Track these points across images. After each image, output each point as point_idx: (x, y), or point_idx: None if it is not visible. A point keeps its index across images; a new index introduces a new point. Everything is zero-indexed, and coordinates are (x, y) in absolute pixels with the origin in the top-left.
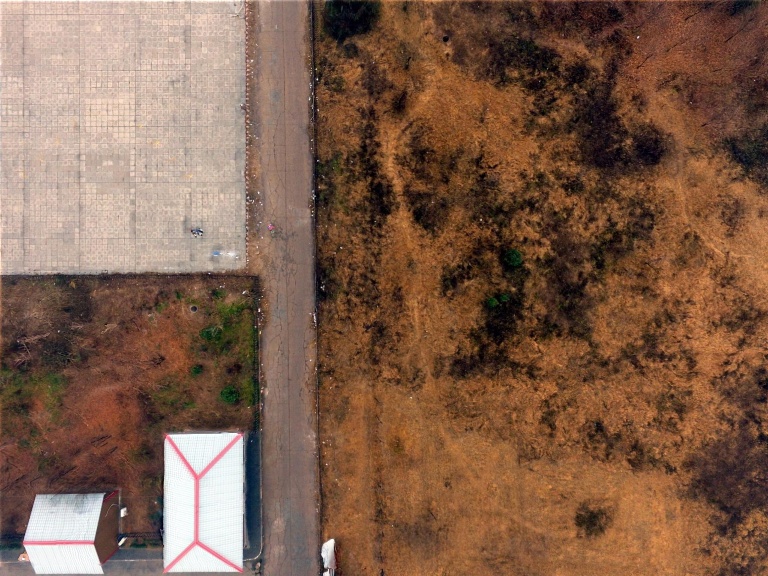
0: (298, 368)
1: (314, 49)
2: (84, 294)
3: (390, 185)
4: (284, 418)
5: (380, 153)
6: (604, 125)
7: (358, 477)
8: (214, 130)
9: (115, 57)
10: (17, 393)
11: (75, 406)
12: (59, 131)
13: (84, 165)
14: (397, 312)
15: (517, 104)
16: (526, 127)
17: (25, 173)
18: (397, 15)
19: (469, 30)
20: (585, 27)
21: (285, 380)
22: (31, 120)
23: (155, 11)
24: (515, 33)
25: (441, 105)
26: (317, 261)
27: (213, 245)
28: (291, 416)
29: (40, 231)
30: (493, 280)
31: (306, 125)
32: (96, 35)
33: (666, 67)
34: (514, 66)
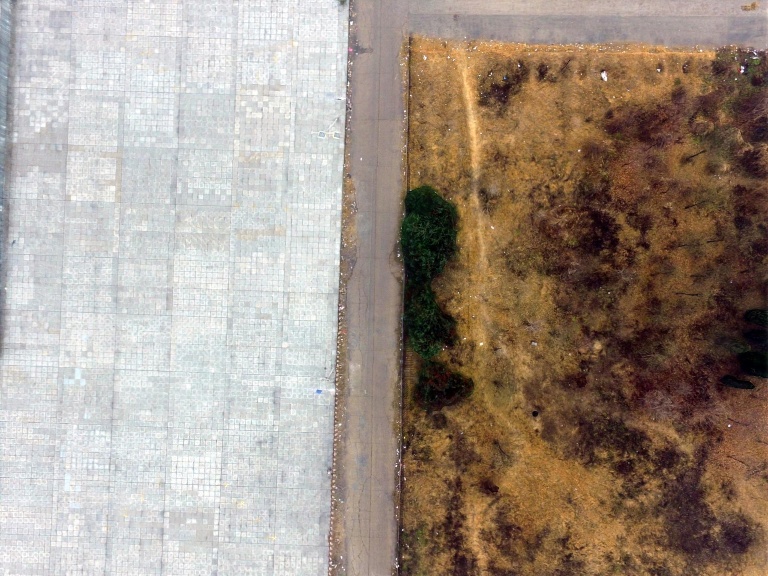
0: None
1: (403, 418)
2: None
3: (475, 559)
4: None
5: (466, 527)
6: (692, 511)
7: None
8: (299, 493)
9: (204, 415)
10: None
11: None
12: (144, 487)
13: (168, 522)
14: None
15: (606, 486)
16: (614, 510)
17: (108, 528)
18: (487, 387)
19: (559, 408)
20: (676, 412)
21: None
22: (117, 475)
23: (245, 371)
24: (605, 414)
25: (529, 483)
26: None
27: None
28: None
29: None
30: None
31: (392, 491)
32: (186, 392)
33: (757, 457)
34: (603, 447)
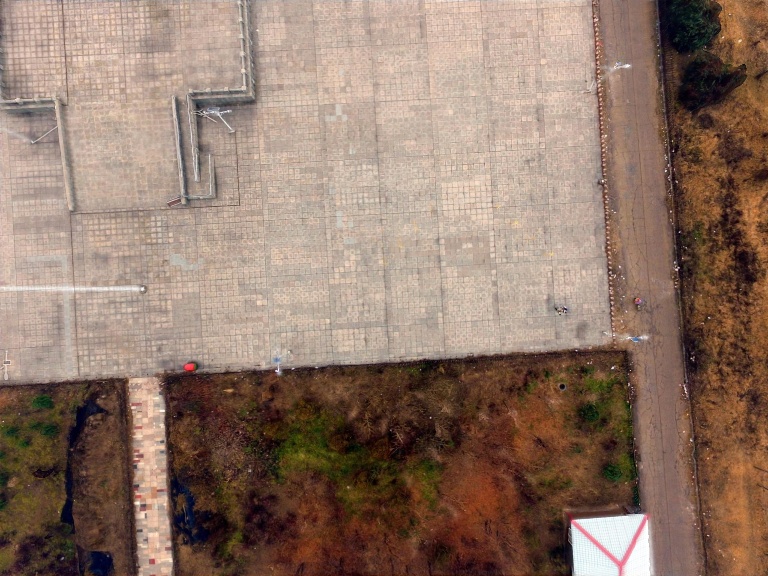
0: (671, 440)
1: (669, 121)
2: (453, 379)
3: (754, 253)
4: (660, 491)
5: (743, 221)
6: None
7: (742, 547)
8: (572, 207)
9: (469, 139)
10: (392, 482)
11: (451, 492)
12: (417, 216)
13: (444, 249)
14: None
15: None
16: None
17: (385, 260)
18: (750, 83)
19: None
20: None
21: (659, 453)
22: (388, 207)
23: (506, 91)
24: None
25: None
26: (686, 332)
27: (578, 322)
28: (668, 489)
29: (403, 318)
30: None
31: (663, 197)
32: (449, 118)
33: None
34: None
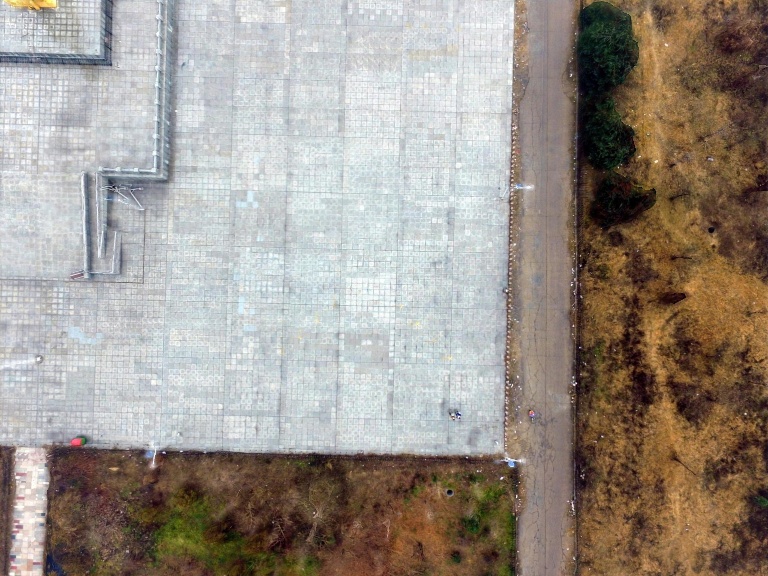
0: (554, 556)
1: (579, 236)
2: (340, 475)
3: (653, 375)
4: None
5: (644, 343)
6: None
7: None
8: (475, 313)
9: (377, 237)
10: (270, 575)
11: None
12: (319, 309)
13: (343, 344)
14: (659, 504)
15: None
16: None
17: (283, 350)
18: (663, 204)
19: (736, 223)
20: None
21: (541, 568)
22: (291, 297)
23: (419, 192)
24: None
25: (707, 297)
26: (577, 449)
27: (471, 429)
28: None
29: (296, 409)
30: (757, 475)
31: (567, 310)
32: (359, 214)
33: None
34: None
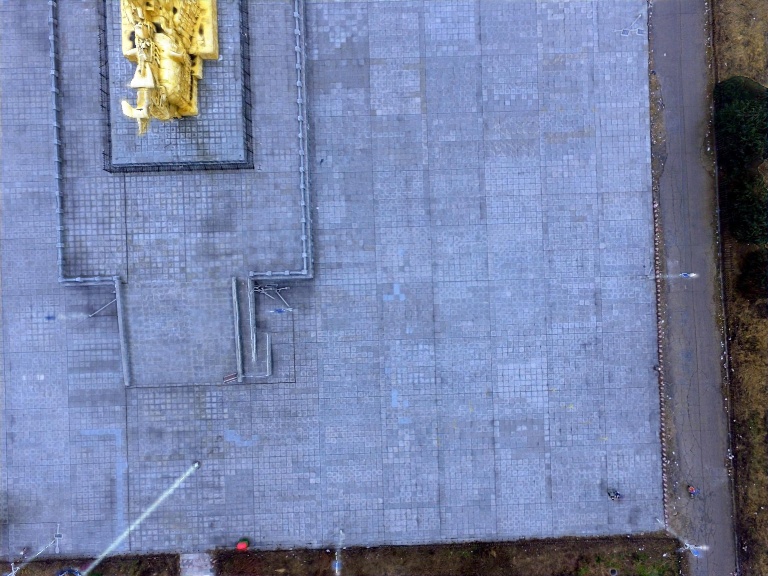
0: None
1: (727, 309)
2: (504, 562)
3: None
4: None
5: None
6: None
7: None
8: (627, 392)
9: (526, 322)
10: None
11: None
12: (472, 397)
13: (498, 431)
14: None
15: None
16: None
17: (439, 441)
18: None
19: None
20: None
21: None
22: (443, 387)
23: (565, 275)
24: None
25: None
26: (738, 522)
27: (631, 507)
28: None
29: (456, 499)
30: None
31: (719, 384)
32: (506, 300)
33: None
34: None
